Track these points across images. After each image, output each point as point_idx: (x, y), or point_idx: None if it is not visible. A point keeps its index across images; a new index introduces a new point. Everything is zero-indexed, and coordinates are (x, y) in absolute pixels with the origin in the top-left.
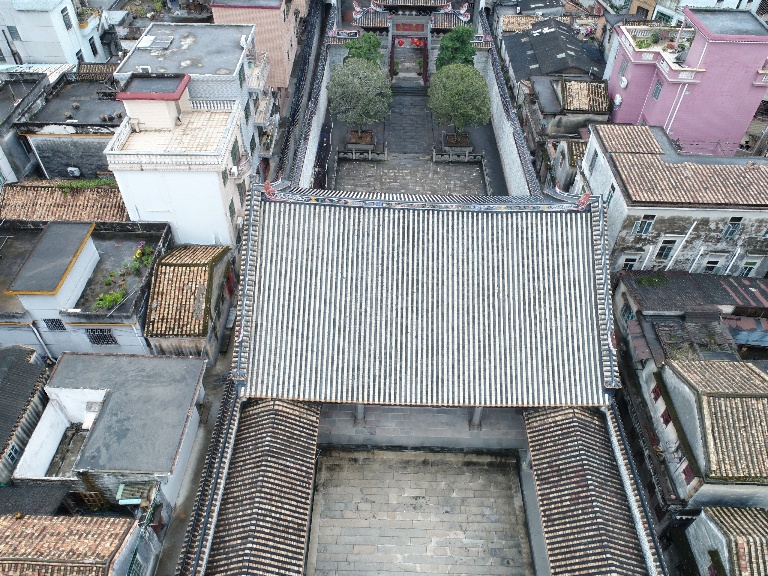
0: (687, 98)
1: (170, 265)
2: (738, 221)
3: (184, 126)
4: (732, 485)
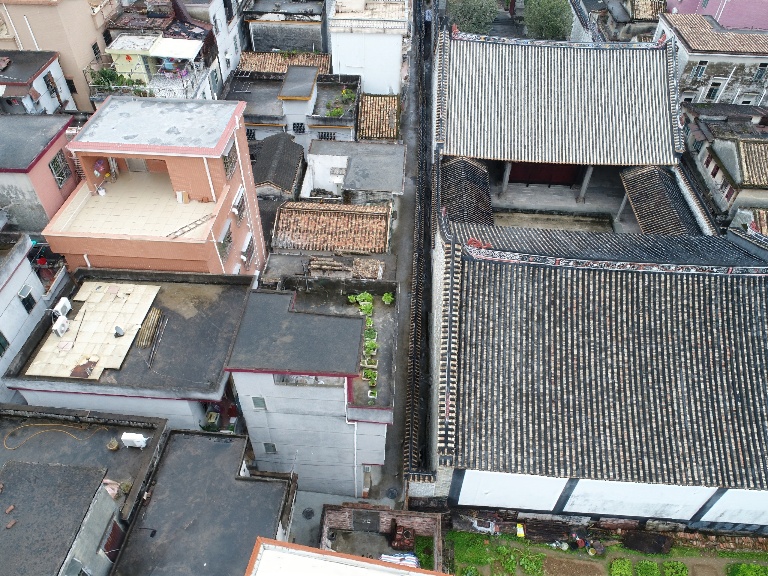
0: (729, 5)
1: (370, 96)
2: (765, 67)
3: (371, 10)
4: (757, 193)
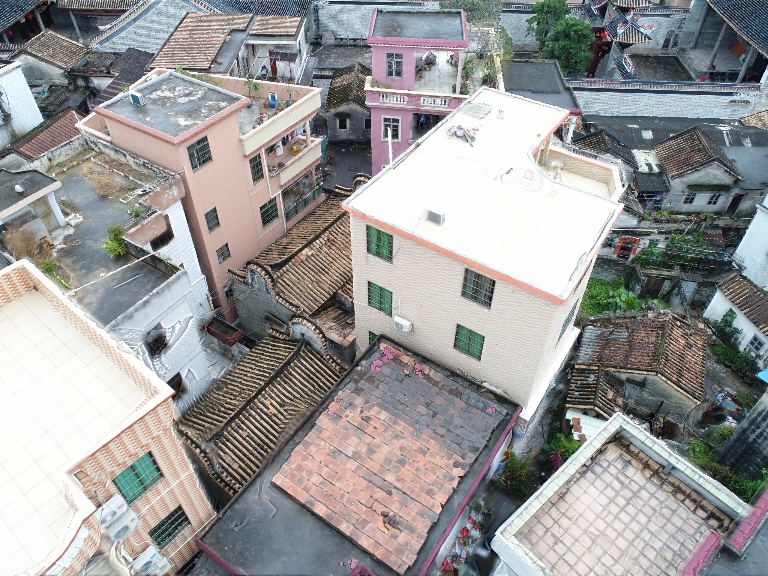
0: None
1: None
2: None
3: None
4: None
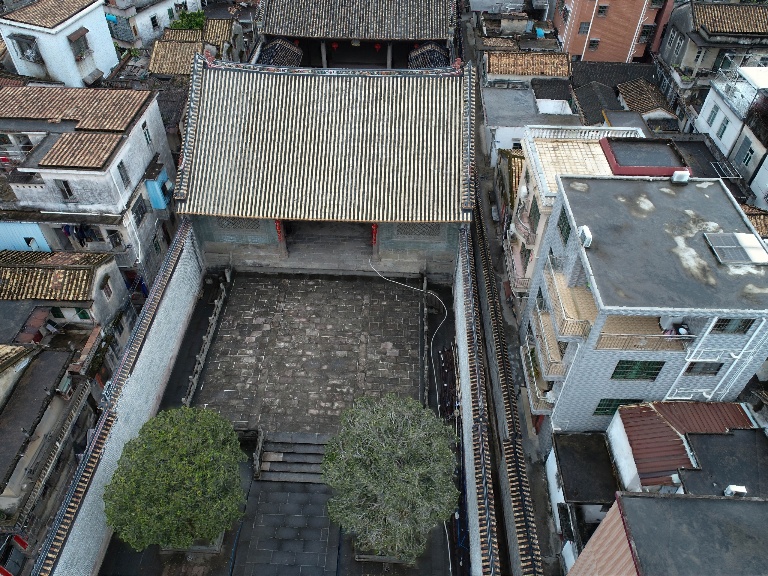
0: None
1: None
2: None
3: None
4: None
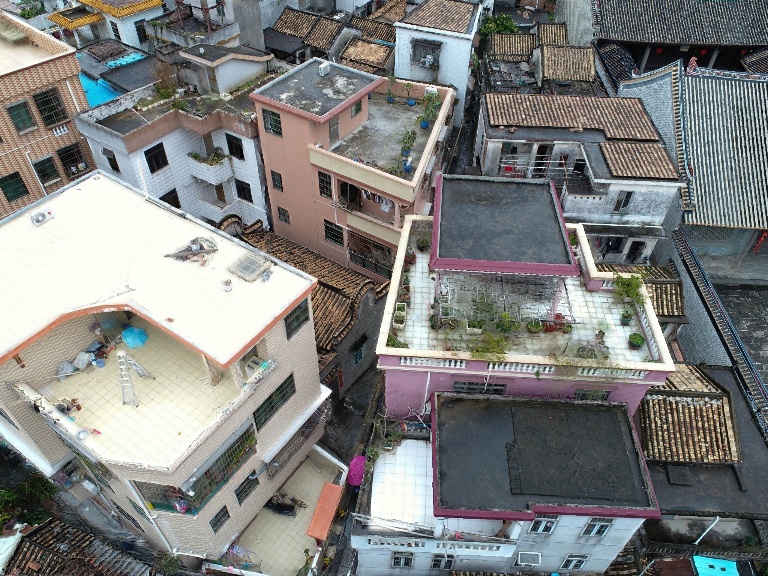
0: None
1: None
2: None
3: None
4: None
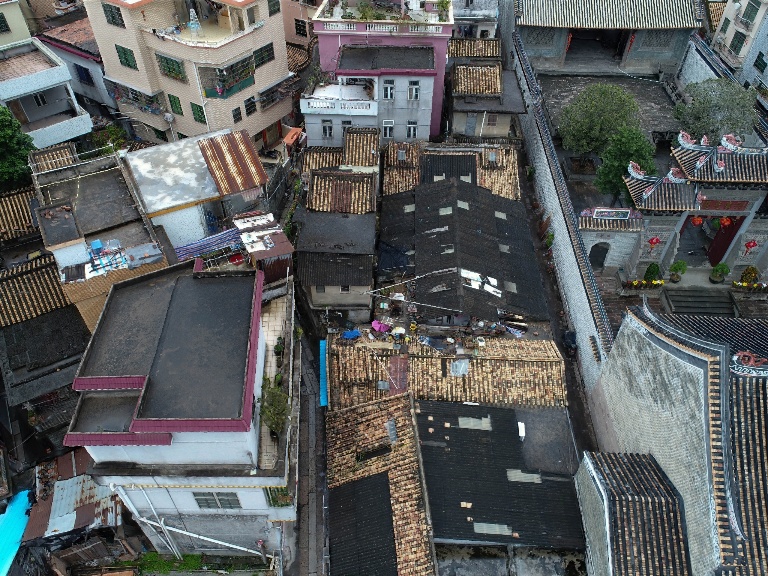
0: None
1: None
2: None
3: None
4: None
